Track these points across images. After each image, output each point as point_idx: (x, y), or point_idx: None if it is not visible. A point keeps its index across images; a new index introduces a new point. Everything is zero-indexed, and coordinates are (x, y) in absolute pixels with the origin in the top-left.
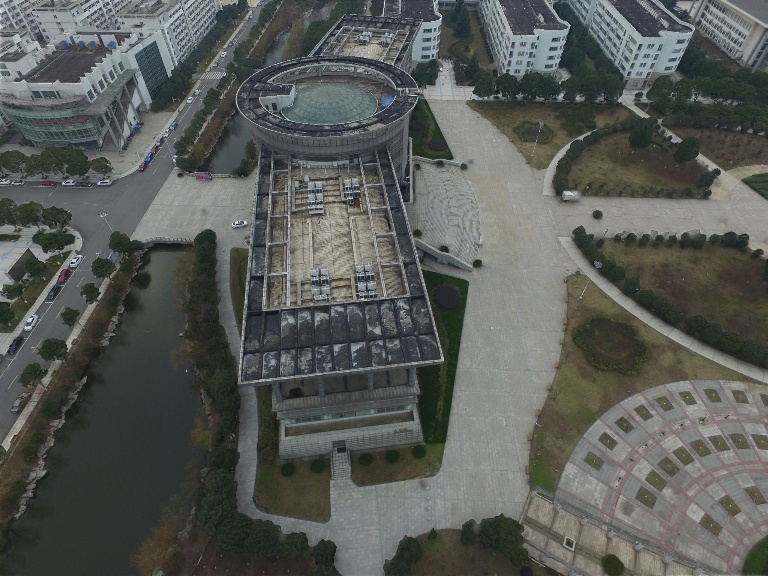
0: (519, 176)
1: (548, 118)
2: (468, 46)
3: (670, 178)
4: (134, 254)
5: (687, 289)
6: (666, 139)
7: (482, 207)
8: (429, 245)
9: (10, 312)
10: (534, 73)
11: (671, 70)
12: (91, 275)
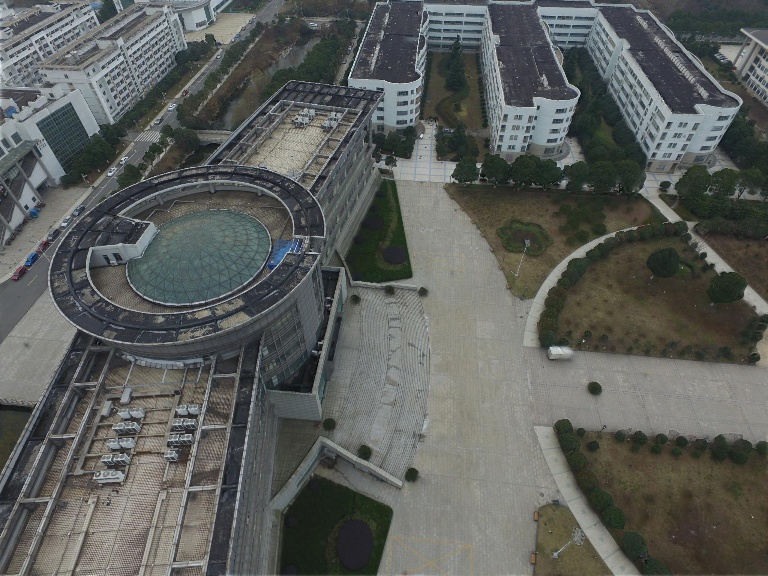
0: (494, 310)
1: (545, 215)
2: (459, 104)
3: (701, 324)
4: None
5: (720, 548)
6: (698, 257)
7: (436, 364)
8: (341, 448)
9: None
10: (529, 156)
11: (709, 150)
12: None
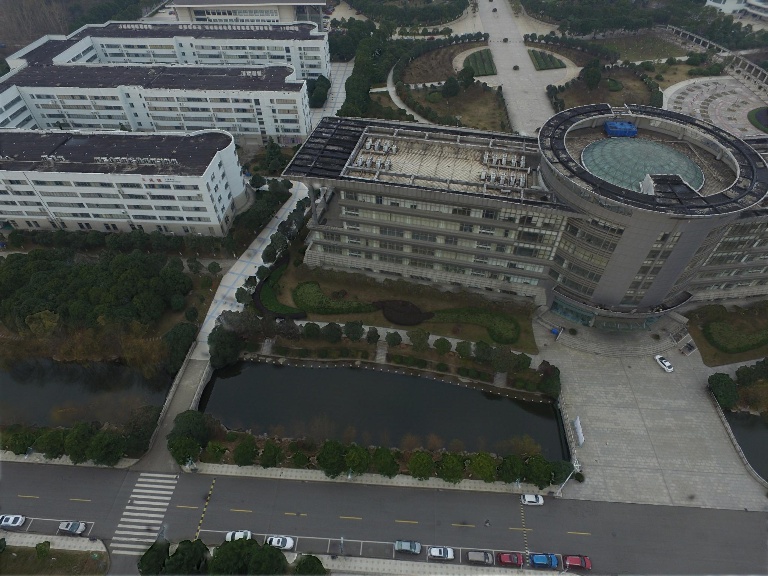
0: None
1: None
2: None
3: (479, 98)
4: None
5: None
6: None
7: None
8: None
9: None
10: (345, 108)
11: None
12: None
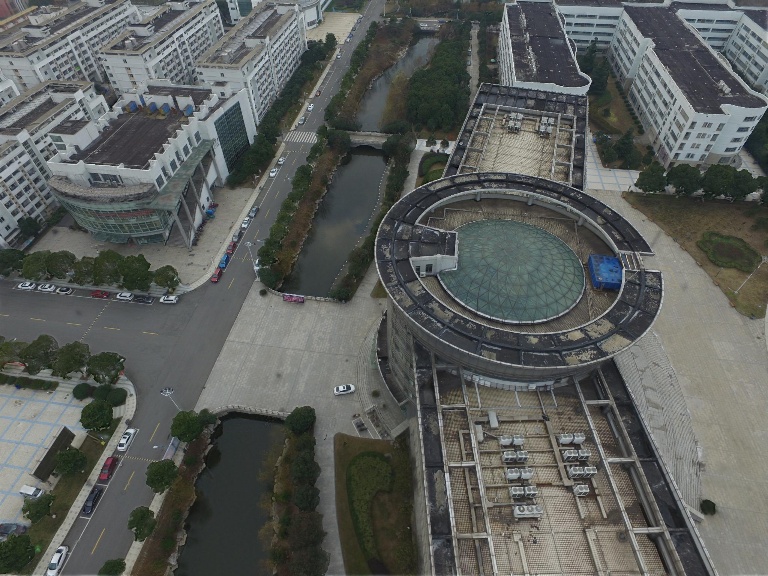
0: (727, 329)
1: (741, 228)
2: (609, 109)
3: None
4: (203, 432)
5: None
6: None
7: (686, 386)
8: None
9: (29, 552)
10: (725, 166)
11: None
12: (144, 469)
